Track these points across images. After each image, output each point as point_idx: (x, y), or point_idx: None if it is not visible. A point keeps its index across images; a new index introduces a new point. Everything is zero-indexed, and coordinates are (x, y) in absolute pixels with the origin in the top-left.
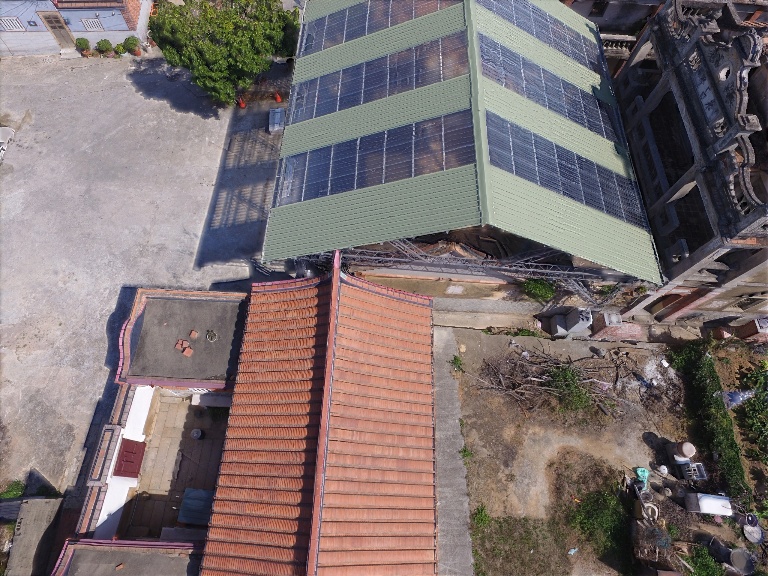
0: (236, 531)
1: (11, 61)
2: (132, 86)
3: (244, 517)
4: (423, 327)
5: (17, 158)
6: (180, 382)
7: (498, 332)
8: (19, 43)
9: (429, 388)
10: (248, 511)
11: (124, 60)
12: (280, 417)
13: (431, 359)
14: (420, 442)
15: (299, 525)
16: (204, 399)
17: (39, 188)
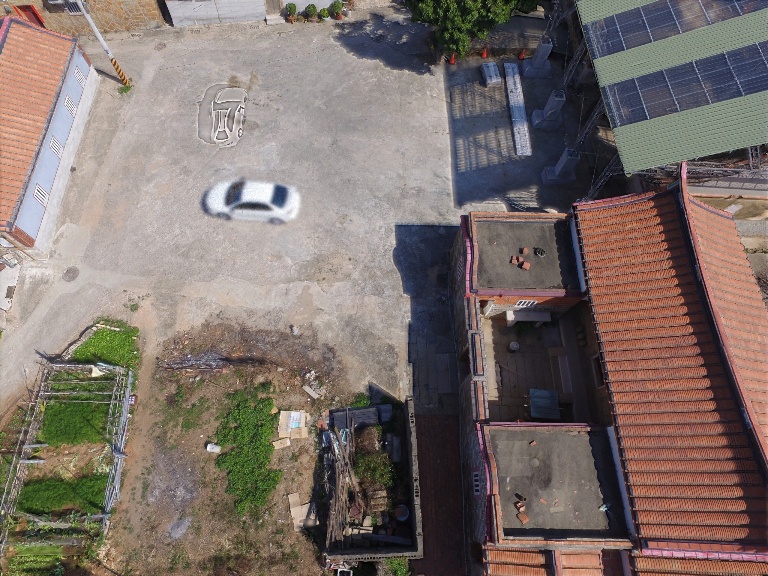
0: (645, 404)
1: (219, 28)
2: (342, 47)
3: (649, 392)
4: (735, 236)
5: (258, 115)
6: (525, 292)
7: (753, 252)
8: (230, 10)
9: (757, 287)
10: (651, 387)
11: (327, 24)
12: (653, 310)
13: (749, 263)
14: (767, 331)
15: (714, 392)
16: (518, 315)
17: (288, 141)
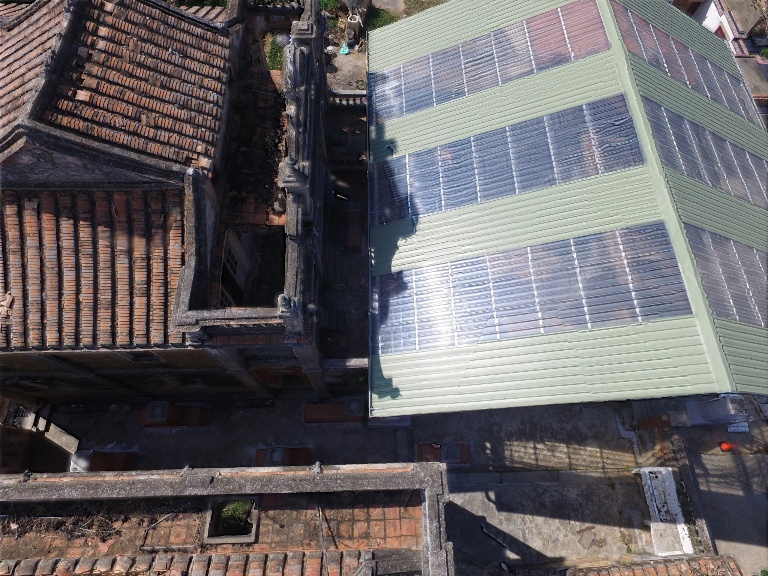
0: None
1: None
2: None
3: None
4: None
5: None
6: None
7: None
8: None
9: None
10: None
11: None
12: None
13: None
14: None
15: None
16: None
17: None
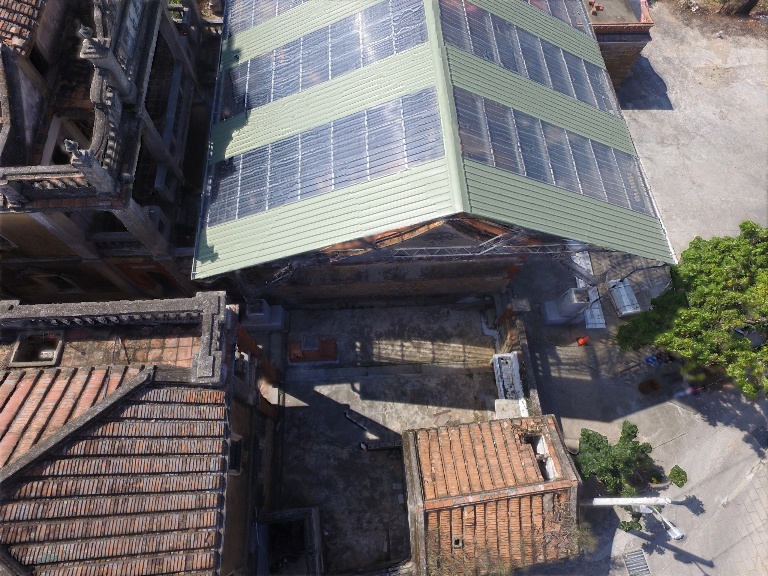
0: None
1: None
2: None
3: None
4: None
5: None
6: None
7: None
8: None
9: None
10: None
11: None
12: None
13: None
14: None
15: None
16: None
17: None
